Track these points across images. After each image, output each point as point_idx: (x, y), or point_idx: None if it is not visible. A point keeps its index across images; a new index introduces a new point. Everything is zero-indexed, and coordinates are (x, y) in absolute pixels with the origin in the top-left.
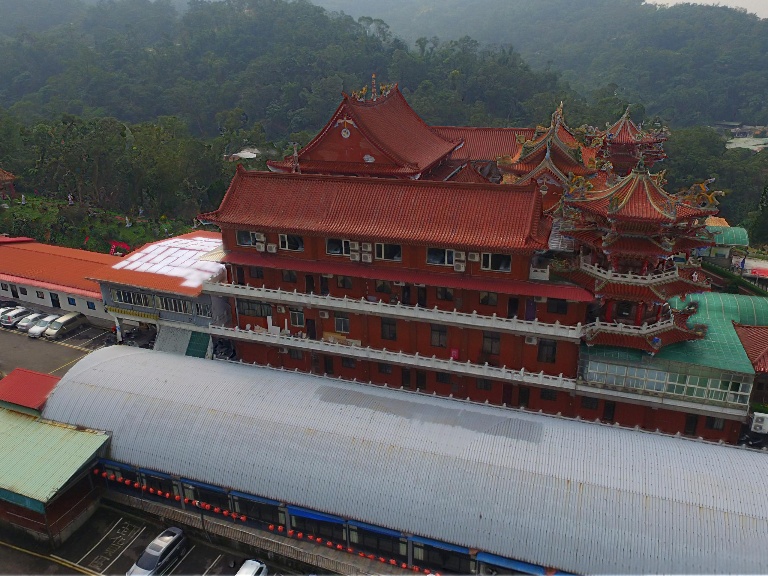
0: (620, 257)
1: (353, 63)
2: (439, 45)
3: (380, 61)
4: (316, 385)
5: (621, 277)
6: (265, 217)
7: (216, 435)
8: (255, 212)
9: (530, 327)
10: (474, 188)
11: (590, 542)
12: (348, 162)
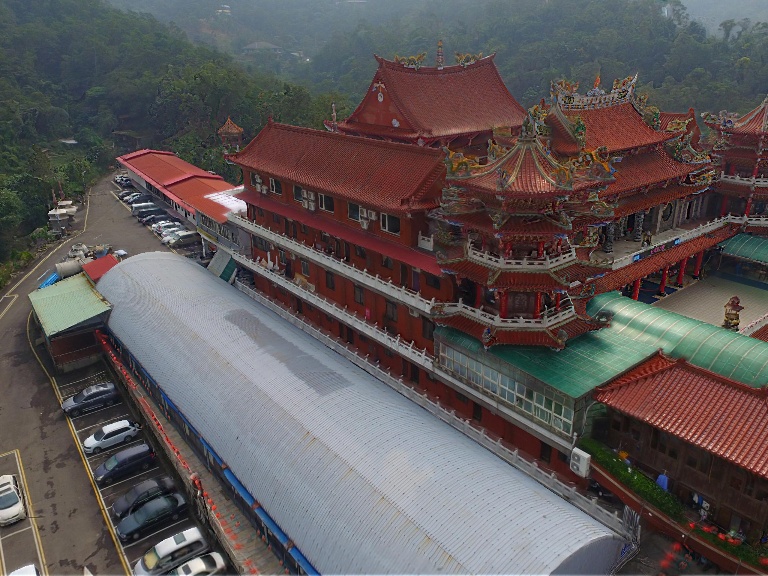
0: (483, 234)
1: (629, 49)
2: (749, 28)
3: (661, 47)
4: (239, 307)
5: (479, 256)
6: (262, 161)
7: (151, 323)
8: (260, 157)
9: (399, 294)
10: (401, 149)
11: (286, 490)
12: (381, 125)
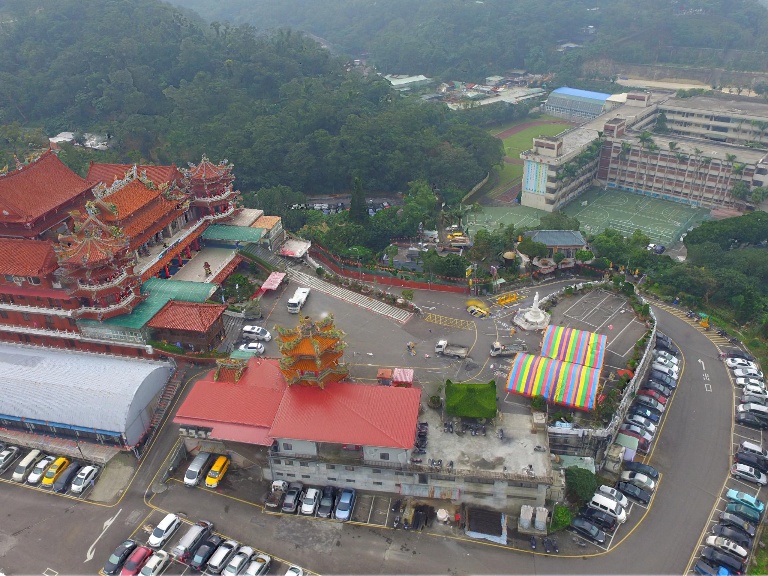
0: None
1: (149, 51)
2: None
3: (172, 49)
4: None
5: (85, 287)
6: None
7: None
8: None
9: (52, 312)
10: (25, 242)
11: (36, 406)
12: None
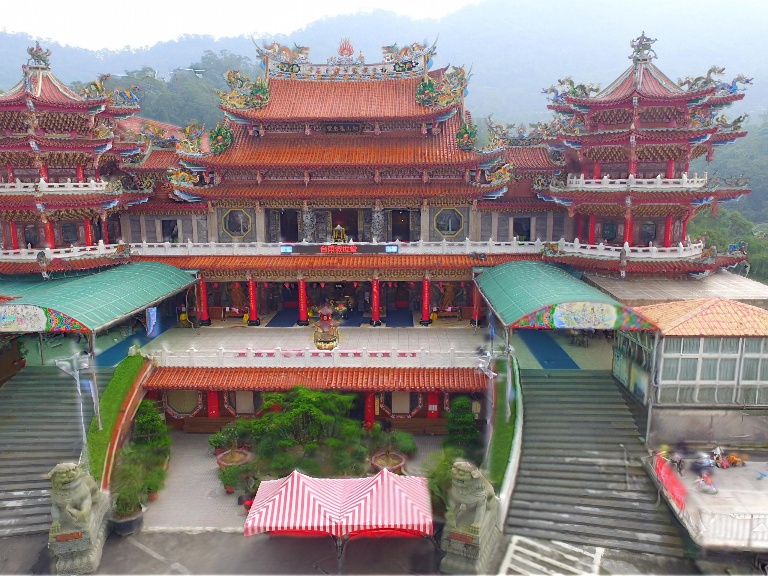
0: None
1: None
2: None
3: None
4: None
5: None
6: None
7: None
8: None
9: None
10: None
11: None
12: None
